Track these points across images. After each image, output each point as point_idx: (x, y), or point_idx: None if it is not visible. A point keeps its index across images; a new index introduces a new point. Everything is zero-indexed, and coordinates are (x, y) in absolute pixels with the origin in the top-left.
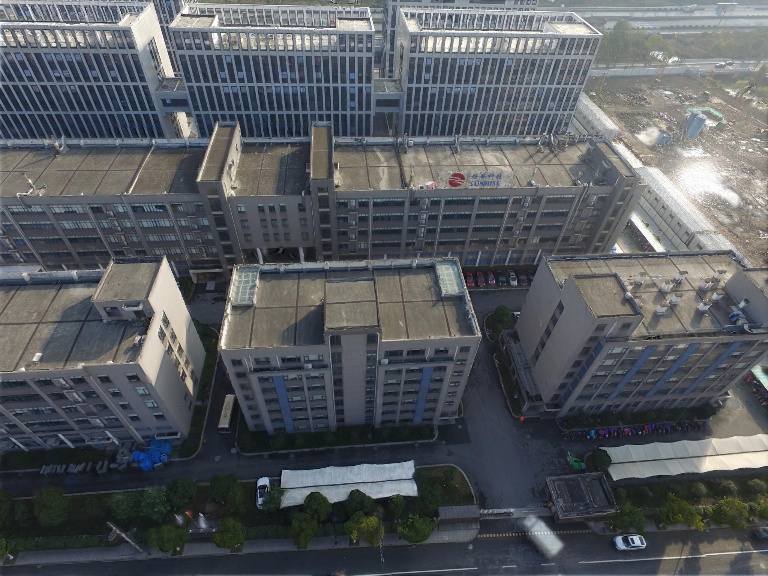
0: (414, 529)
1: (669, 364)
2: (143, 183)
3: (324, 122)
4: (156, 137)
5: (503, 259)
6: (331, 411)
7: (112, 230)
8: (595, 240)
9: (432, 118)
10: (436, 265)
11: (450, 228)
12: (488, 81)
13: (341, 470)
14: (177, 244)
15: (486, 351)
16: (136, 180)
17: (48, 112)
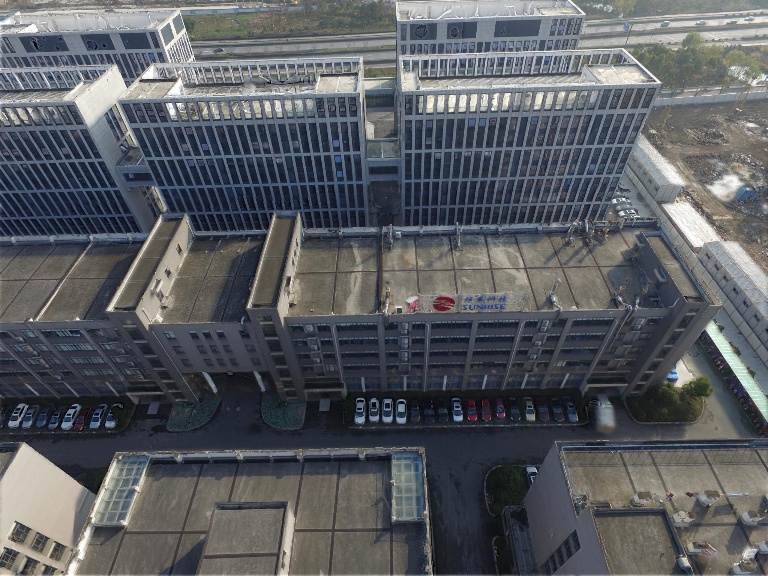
0: None
1: None
2: (61, 299)
3: (289, 212)
4: (122, 213)
5: (518, 382)
6: None
7: (28, 354)
8: (644, 368)
9: (438, 186)
10: (392, 459)
11: (443, 351)
12: (507, 143)
13: None
14: (107, 366)
15: (483, 532)
16: (55, 295)
17: (4, 191)
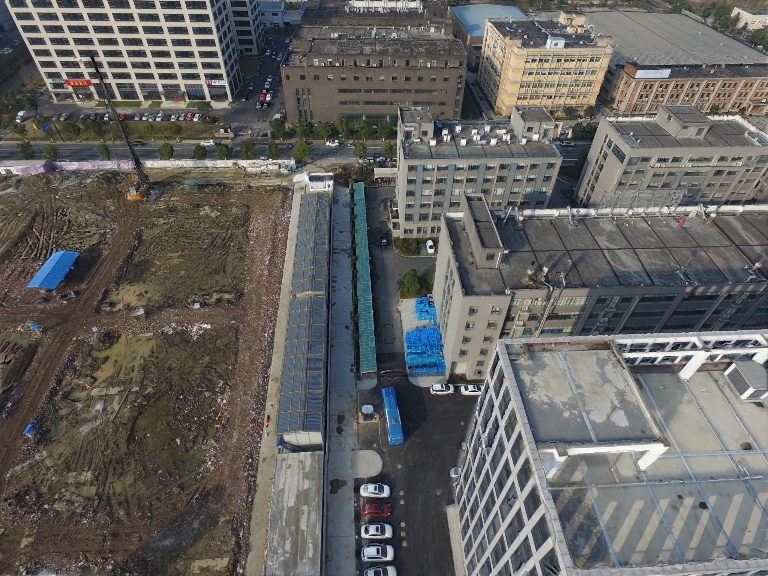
0: None
1: None
2: None
3: None
4: None
5: None
6: None
7: None
8: None
9: None
10: None
11: None
12: None
13: None
14: None
15: None
16: None
17: None
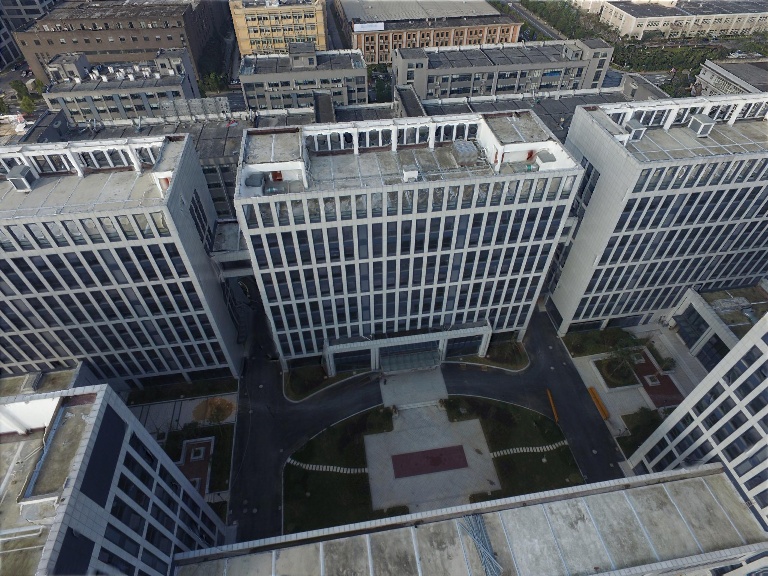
0: None
1: None
2: None
3: None
4: None
5: None
6: None
7: None
8: None
9: None
10: None
11: None
12: None
13: None
14: None
15: None
16: None
17: None
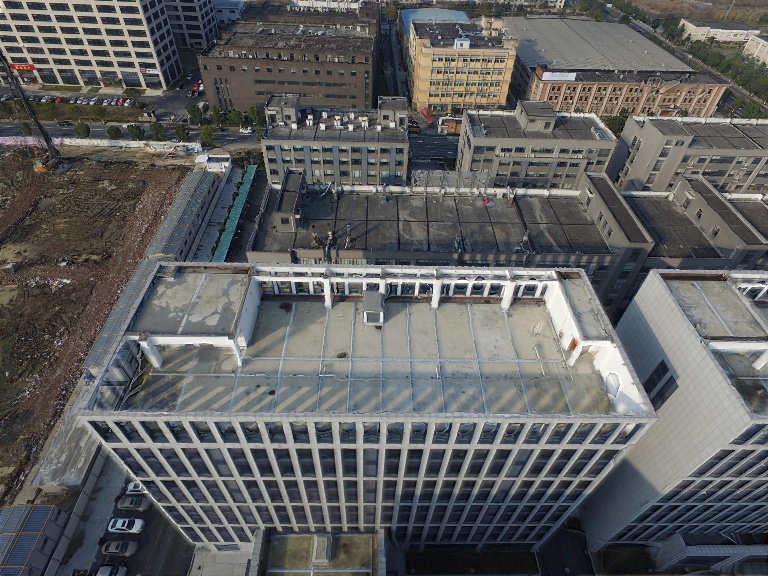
0: None
1: None
2: (767, 214)
3: (639, 243)
4: None
5: None
6: None
7: None
8: None
9: None
10: None
11: None
12: None
13: None
14: None
15: None
16: None
17: None
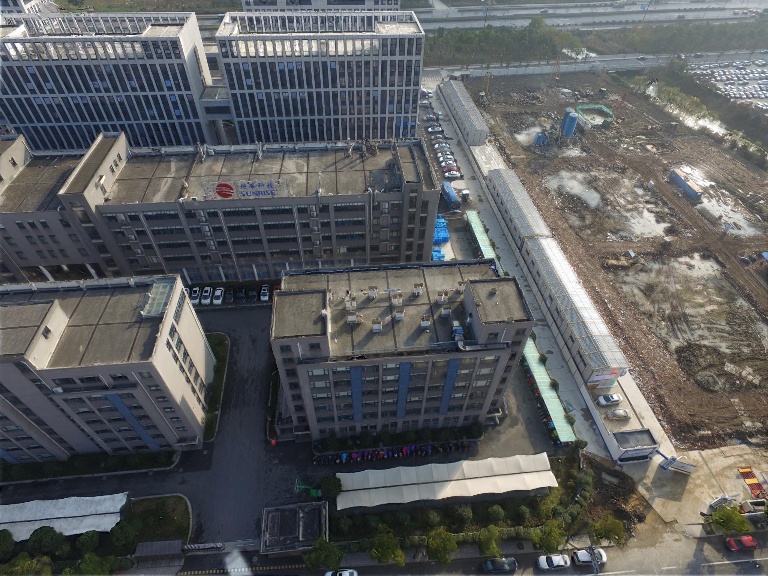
0: (79, 571)
1: (394, 384)
2: None
3: (114, 133)
4: None
5: None
6: (41, 441)
7: None
8: (403, 248)
9: (267, 124)
10: (154, 283)
11: (242, 240)
12: (316, 85)
13: (44, 504)
14: None
15: (266, 369)
16: None
17: None
